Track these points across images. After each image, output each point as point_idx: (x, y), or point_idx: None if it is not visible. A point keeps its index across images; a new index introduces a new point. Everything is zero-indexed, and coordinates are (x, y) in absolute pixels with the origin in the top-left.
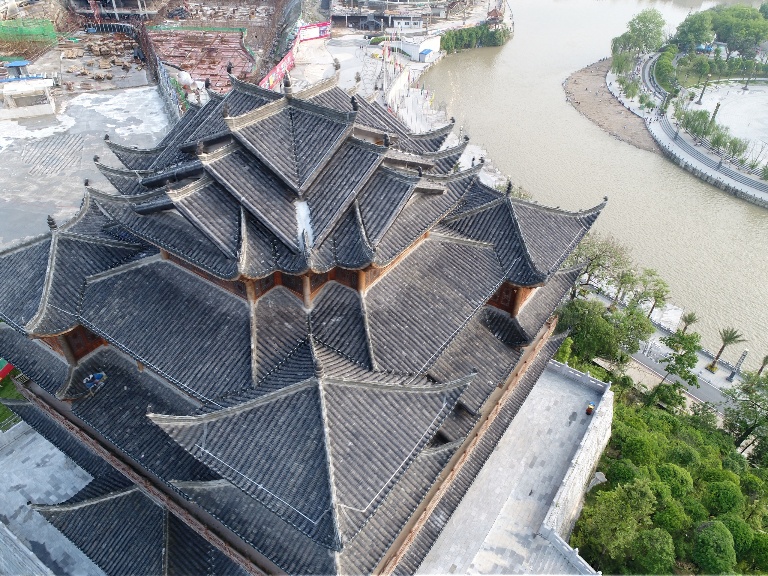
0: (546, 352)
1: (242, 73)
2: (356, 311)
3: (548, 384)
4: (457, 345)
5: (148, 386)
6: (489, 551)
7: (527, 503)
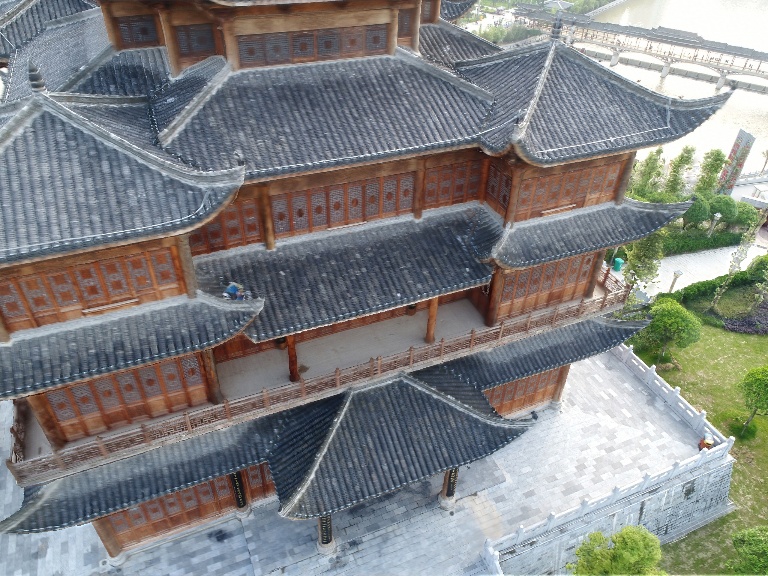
0: None
1: None
2: (452, 36)
3: None
4: None
5: (304, 253)
6: None
7: None
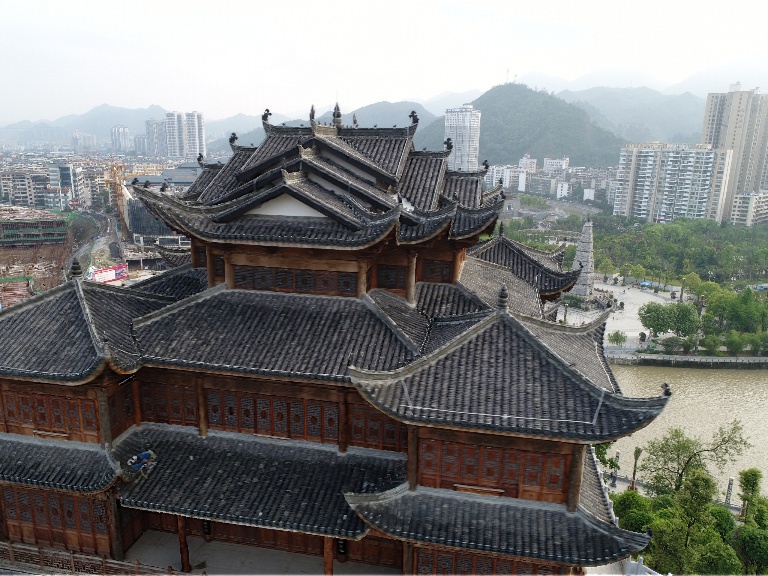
0: None
1: None
2: (461, 297)
3: None
4: None
5: (223, 448)
6: None
7: None
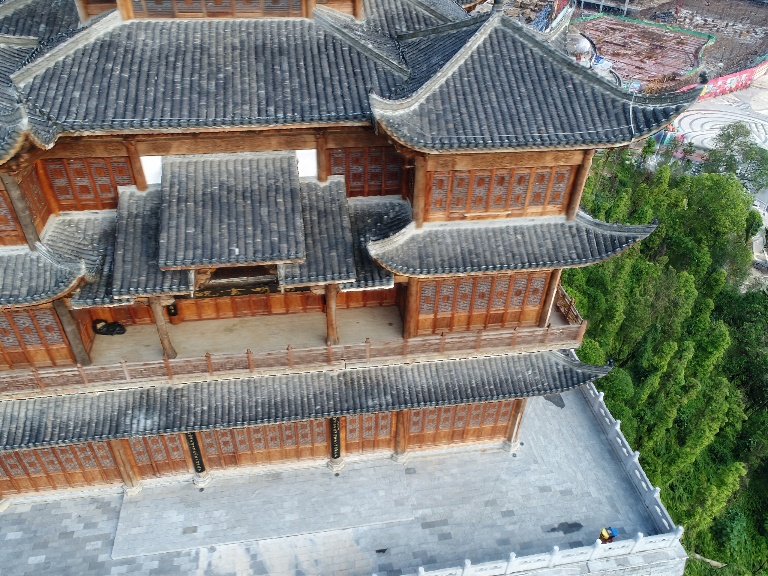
0: (550, 379)
1: (673, 74)
2: None
3: (586, 464)
4: (245, 181)
5: None
6: (248, 555)
7: (361, 555)
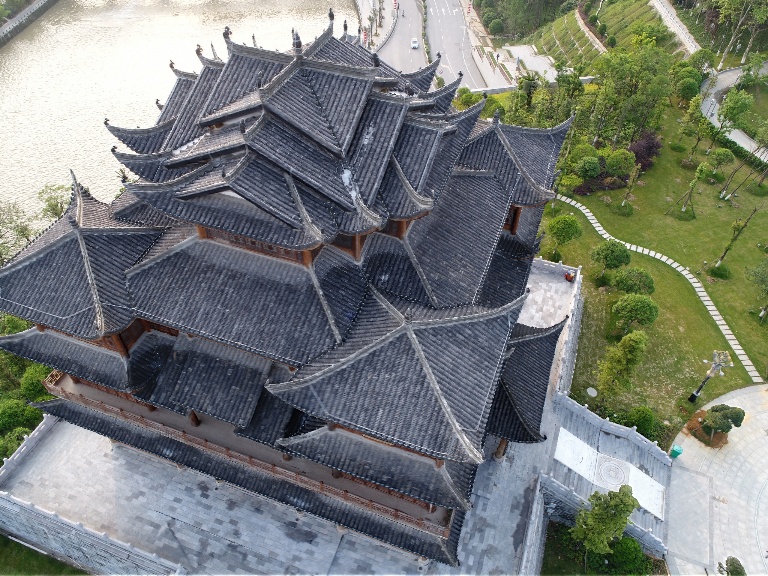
0: None
1: None
2: None
3: None
4: None
5: None
6: None
7: None
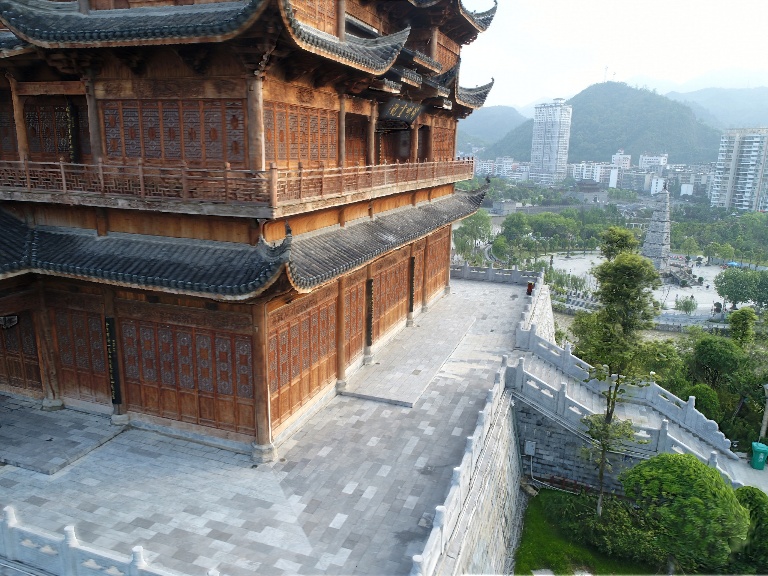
0: (470, 204)
1: None
2: None
3: (477, 285)
4: None
5: None
6: (459, 362)
7: (491, 335)
